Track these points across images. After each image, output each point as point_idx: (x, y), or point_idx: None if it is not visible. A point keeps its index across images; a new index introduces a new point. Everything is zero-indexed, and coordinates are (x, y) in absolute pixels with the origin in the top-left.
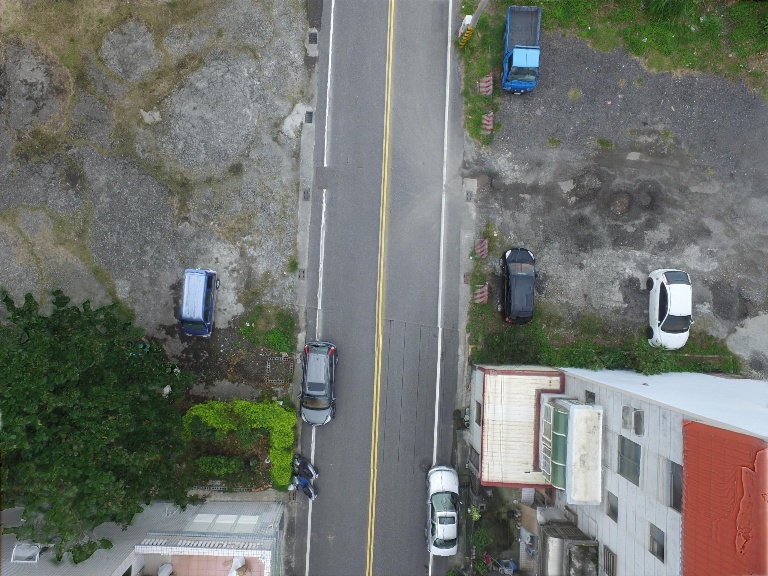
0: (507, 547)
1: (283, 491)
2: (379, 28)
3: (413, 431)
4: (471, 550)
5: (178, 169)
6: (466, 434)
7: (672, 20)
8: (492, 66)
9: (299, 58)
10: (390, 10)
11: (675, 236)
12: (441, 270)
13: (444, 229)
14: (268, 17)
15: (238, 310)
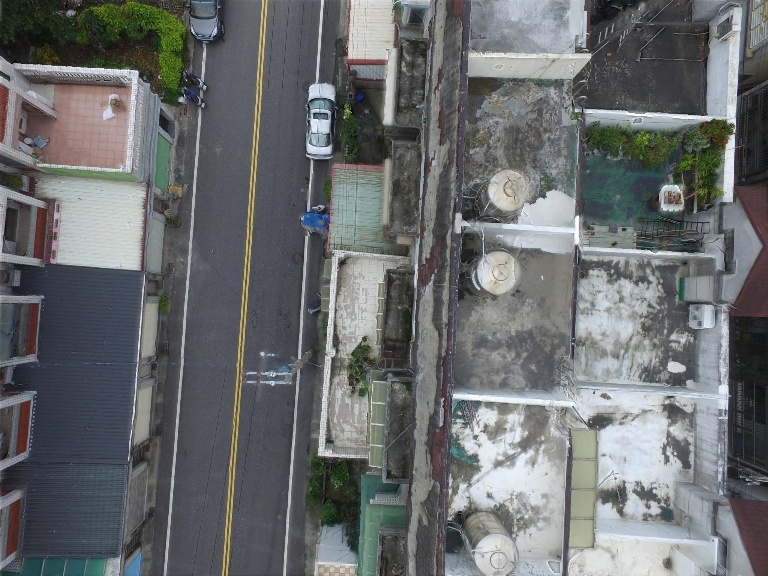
0: (382, 161)
1: (175, 106)
2: None
3: (297, 56)
4: (344, 148)
5: None
6: (346, 59)
7: None
8: None
9: None
10: None
11: None
12: None
13: None
14: None
15: None
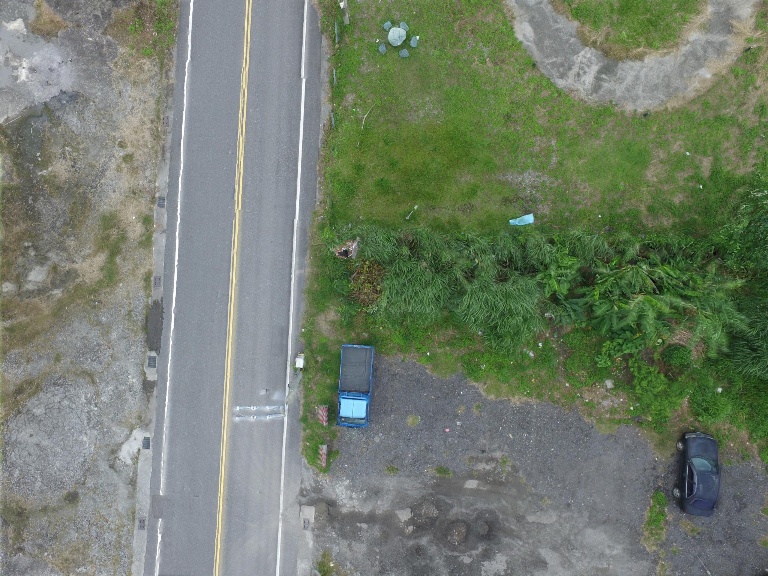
0: None
1: None
2: (217, 353)
3: None
4: None
5: (13, 498)
6: None
7: (509, 349)
8: (330, 392)
9: (138, 382)
10: (228, 337)
11: (512, 567)
12: None
13: (280, 559)
14: (107, 341)
15: None
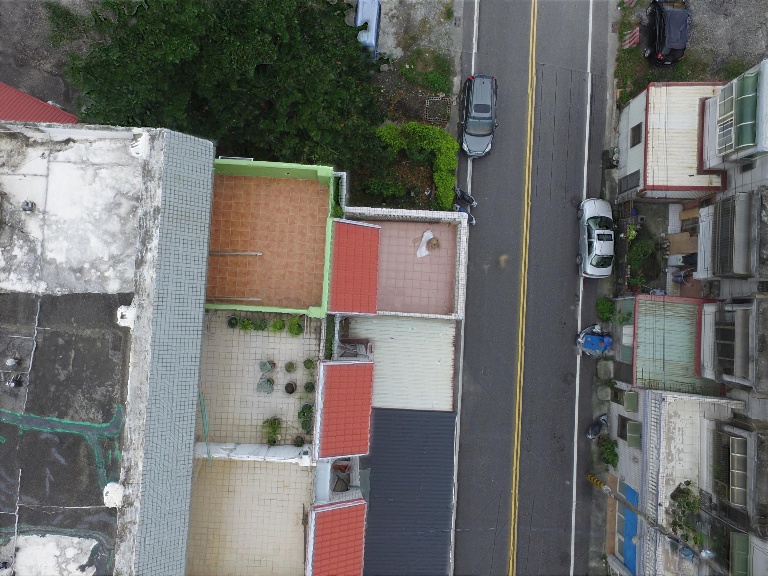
0: (654, 277)
1: None
2: None
3: (564, 169)
4: (626, 269)
5: None
6: (615, 172)
7: None
8: None
9: None
10: None
11: None
12: (591, 18)
13: None
14: None
15: (398, 53)
